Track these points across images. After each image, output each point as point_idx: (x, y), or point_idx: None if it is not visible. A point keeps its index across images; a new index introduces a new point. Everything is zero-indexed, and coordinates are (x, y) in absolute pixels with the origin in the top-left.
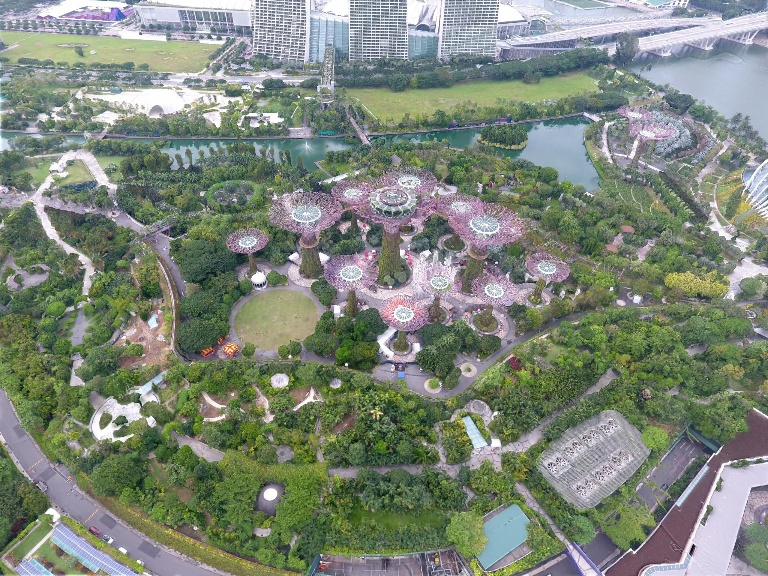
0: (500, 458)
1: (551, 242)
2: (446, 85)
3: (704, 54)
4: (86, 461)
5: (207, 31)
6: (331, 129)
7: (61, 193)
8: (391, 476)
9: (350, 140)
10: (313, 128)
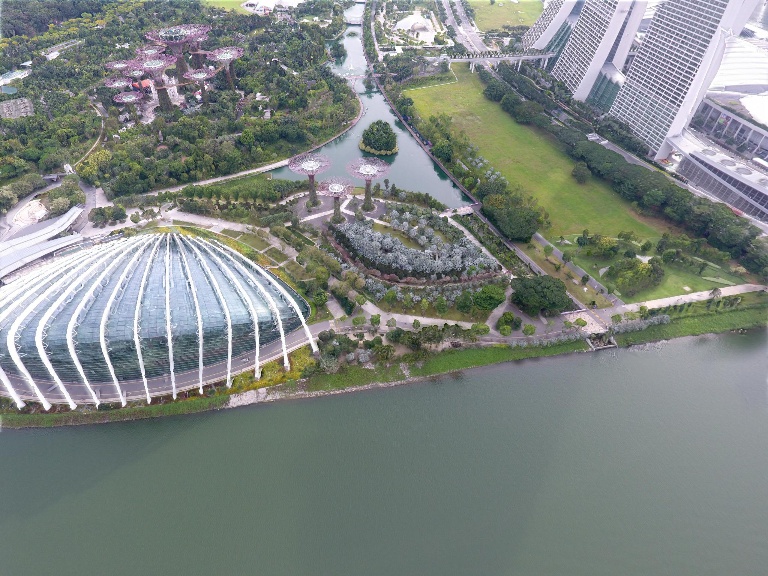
0: None
1: None
2: (517, 119)
3: None
4: None
5: None
6: None
7: None
8: None
9: None
10: None
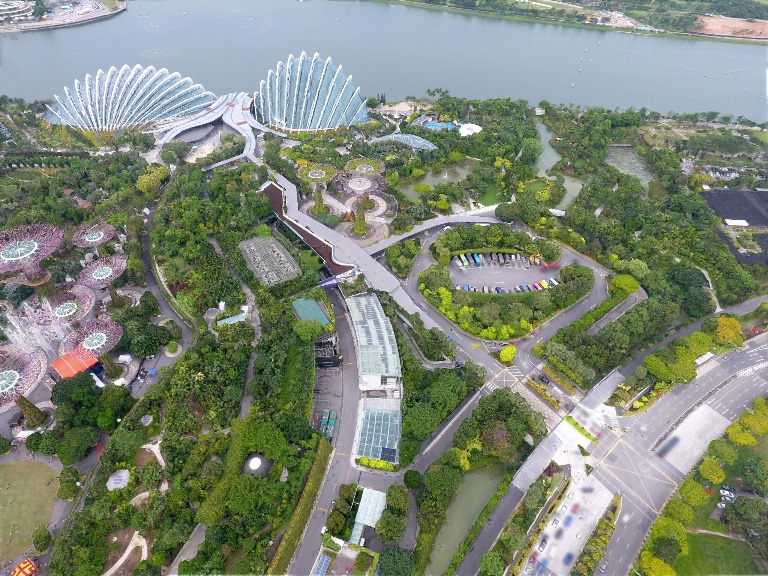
0: (256, 310)
1: None
2: None
3: None
4: None
5: None
6: None
7: None
8: (260, 367)
9: None
10: None
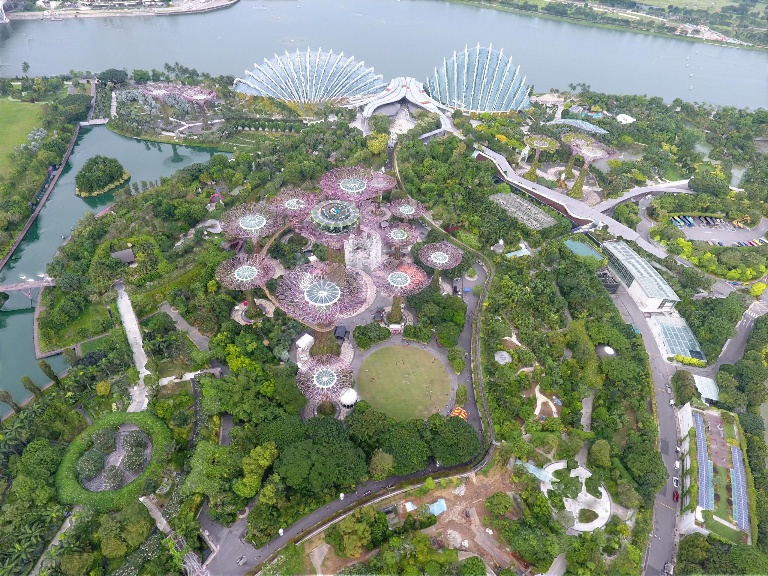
0: (529, 248)
1: None
2: None
3: None
4: None
5: None
6: None
7: None
8: (573, 285)
9: None
10: None
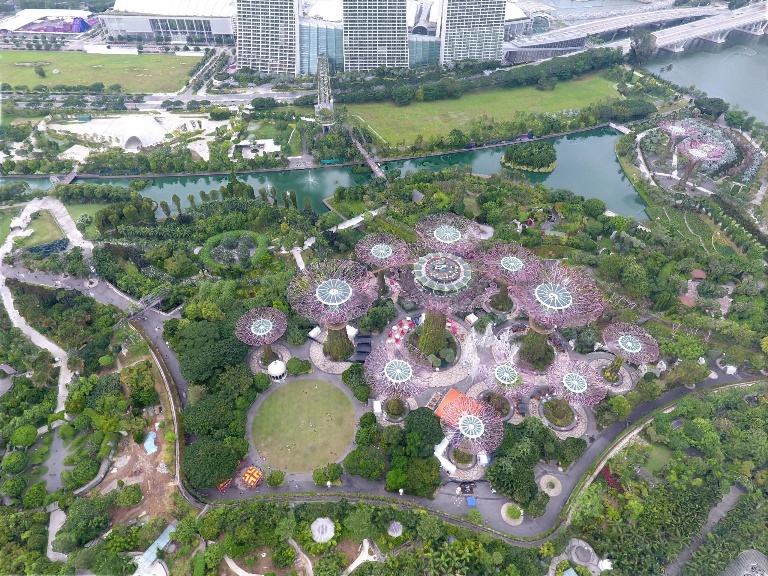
0: None
1: (616, 297)
2: (455, 96)
3: (716, 47)
4: None
5: (183, 41)
6: (336, 157)
7: (25, 259)
8: None
9: (358, 169)
10: (315, 157)
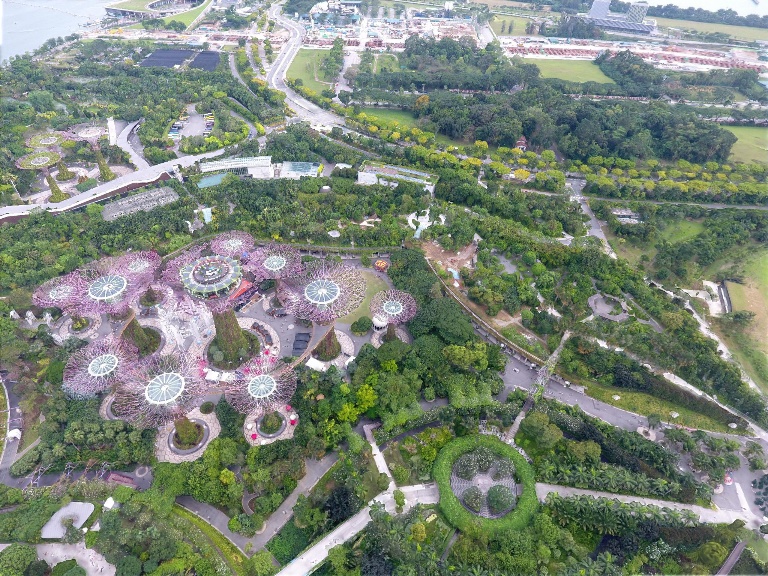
0: None
1: None
2: None
3: None
4: (426, 191)
5: None
6: None
7: None
8: None
9: None
10: None
